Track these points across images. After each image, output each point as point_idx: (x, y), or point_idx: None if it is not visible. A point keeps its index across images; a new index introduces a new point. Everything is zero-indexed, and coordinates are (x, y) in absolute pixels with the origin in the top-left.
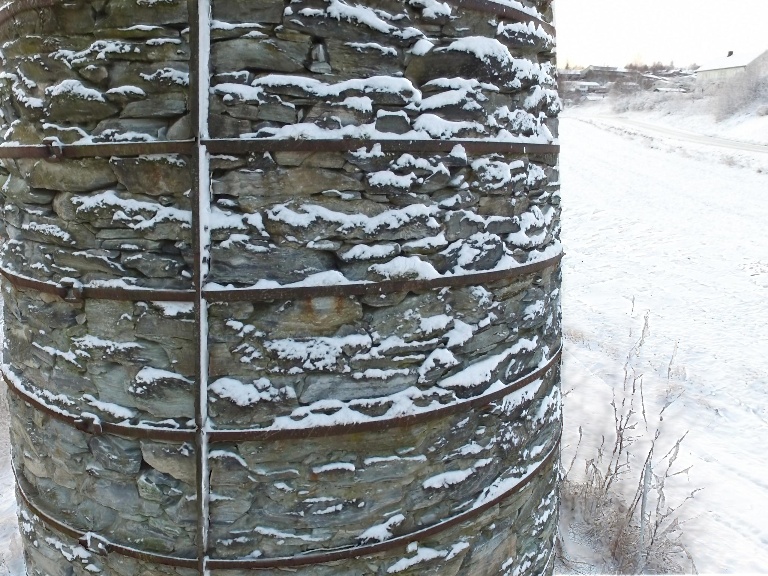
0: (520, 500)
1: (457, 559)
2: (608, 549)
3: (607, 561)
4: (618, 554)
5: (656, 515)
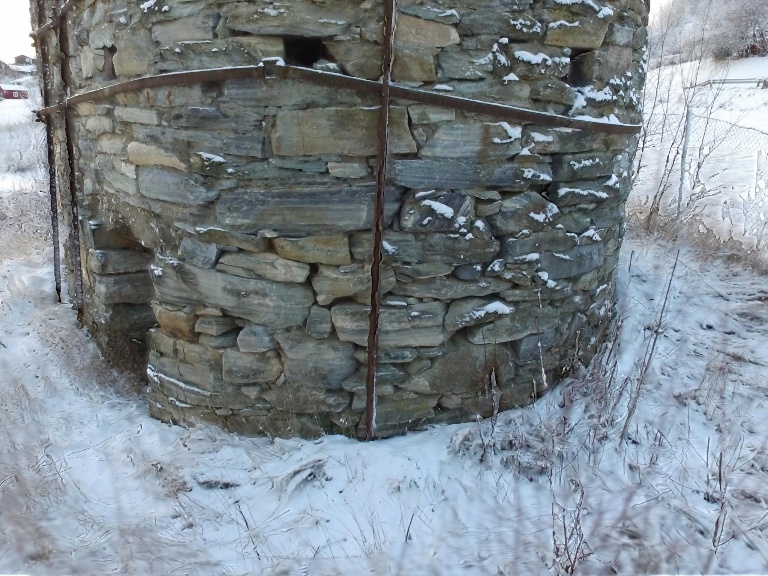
0: (637, 16)
1: (604, 25)
2: (640, 229)
3: (642, 235)
4: (652, 227)
5: (700, 153)
